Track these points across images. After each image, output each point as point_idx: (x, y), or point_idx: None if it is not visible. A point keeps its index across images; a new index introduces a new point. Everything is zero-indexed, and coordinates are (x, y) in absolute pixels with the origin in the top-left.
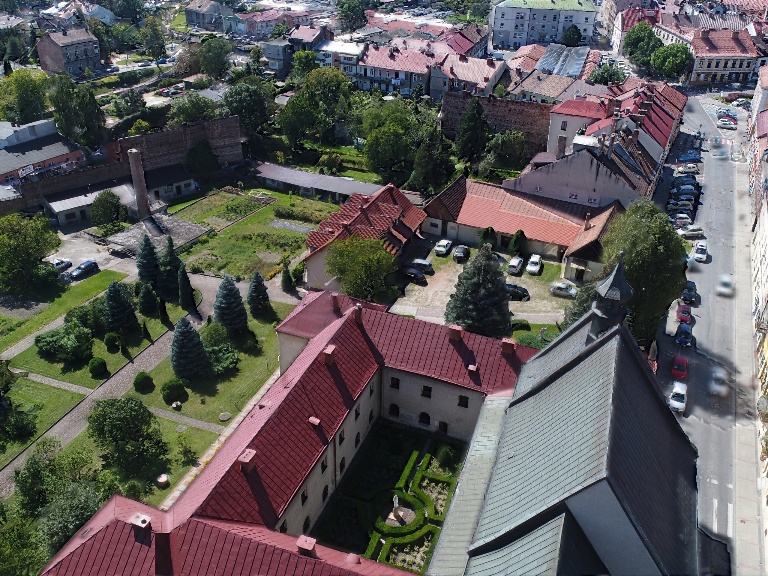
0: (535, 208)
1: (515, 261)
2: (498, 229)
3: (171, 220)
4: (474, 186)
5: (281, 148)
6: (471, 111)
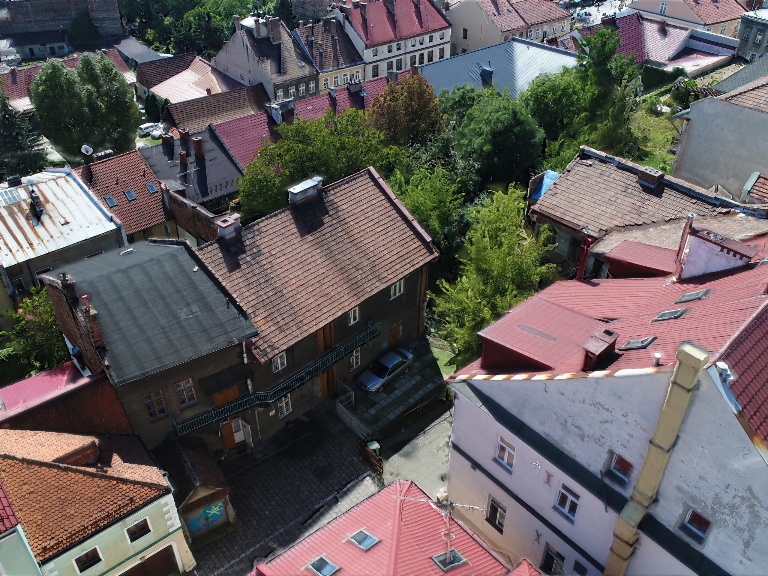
0: (215, 86)
1: (147, 124)
2: (168, 98)
3: (3, 68)
4: (197, 63)
5: (160, 27)
6: (278, 1)
